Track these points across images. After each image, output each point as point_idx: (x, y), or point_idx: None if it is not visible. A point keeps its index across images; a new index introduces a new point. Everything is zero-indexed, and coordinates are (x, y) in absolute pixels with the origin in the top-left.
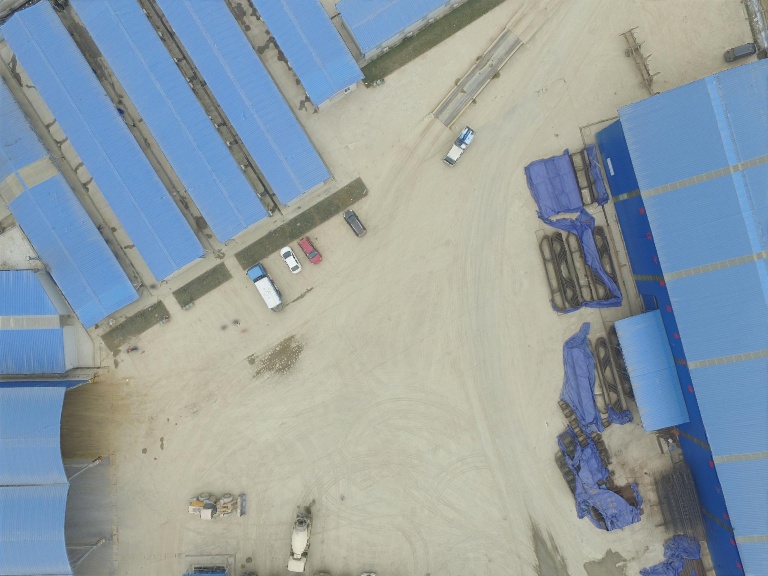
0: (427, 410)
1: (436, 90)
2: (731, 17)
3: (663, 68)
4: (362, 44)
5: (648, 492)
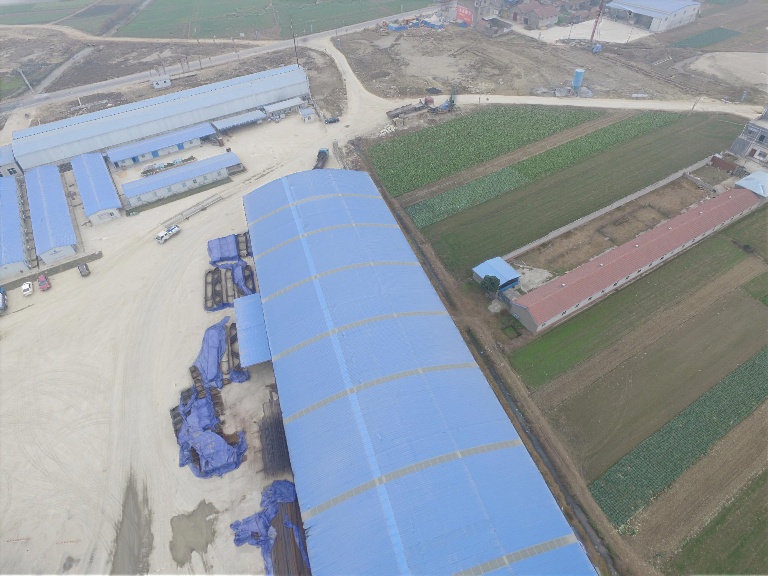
0: (76, 378)
1: (167, 216)
2: None
3: None
4: (127, 195)
5: (254, 439)
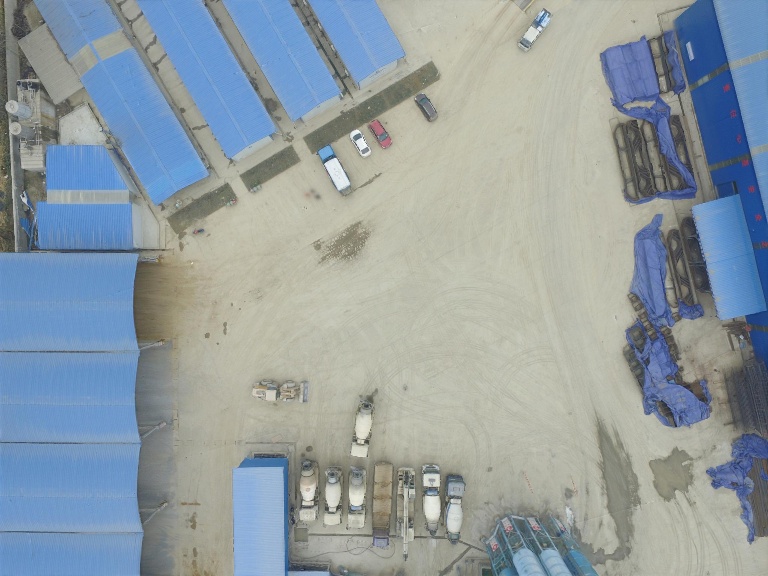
0: (494, 300)
1: None
2: None
3: None
4: None
5: (717, 390)
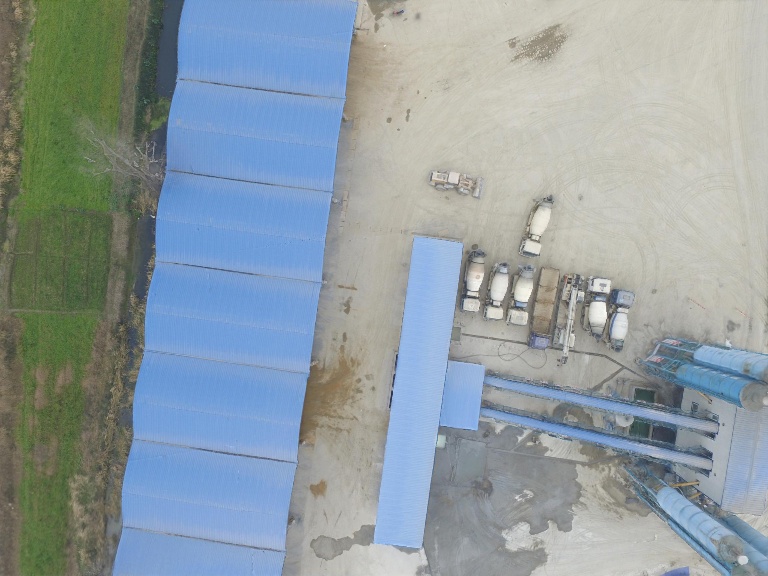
0: (682, 120)
1: None
2: None
3: None
4: None
5: None
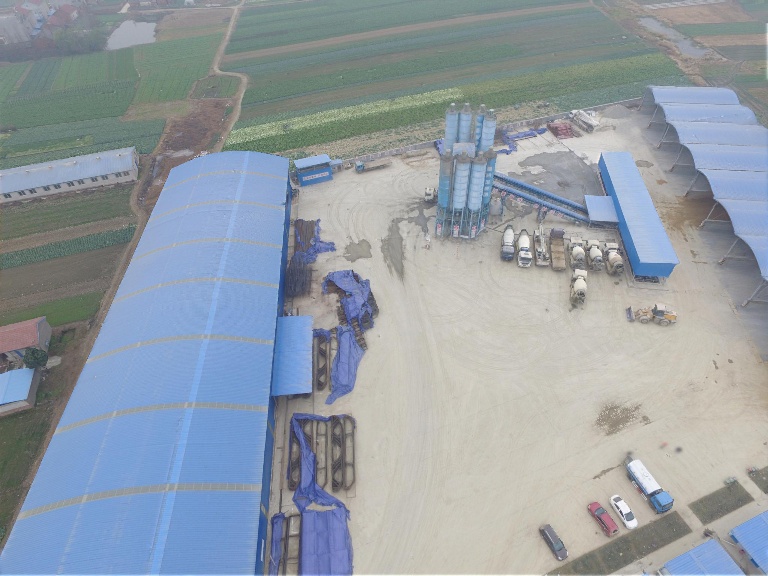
0: (477, 358)
1: None
2: None
3: None
4: None
5: (316, 288)
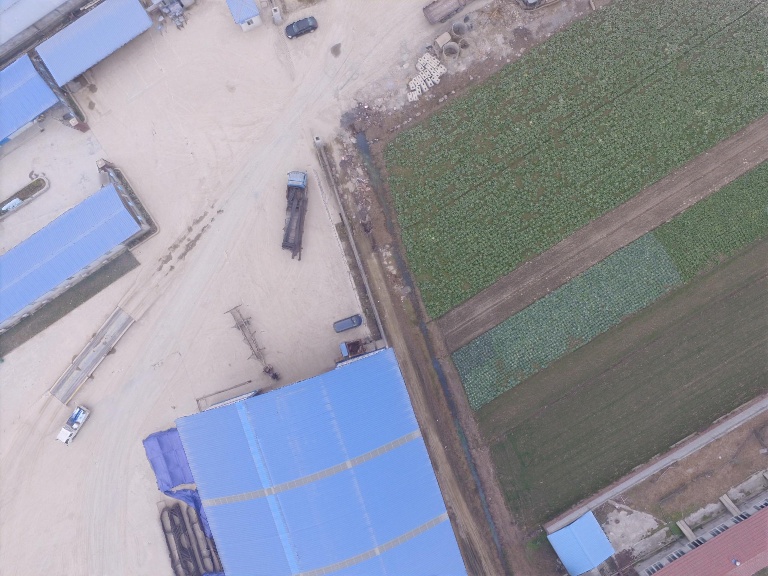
0: None
1: (54, 367)
2: (339, 288)
3: (275, 339)
4: None
5: None
